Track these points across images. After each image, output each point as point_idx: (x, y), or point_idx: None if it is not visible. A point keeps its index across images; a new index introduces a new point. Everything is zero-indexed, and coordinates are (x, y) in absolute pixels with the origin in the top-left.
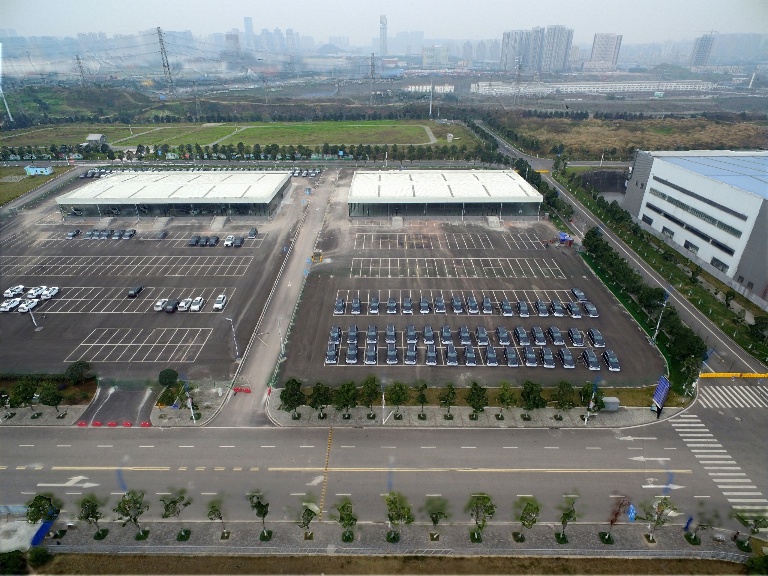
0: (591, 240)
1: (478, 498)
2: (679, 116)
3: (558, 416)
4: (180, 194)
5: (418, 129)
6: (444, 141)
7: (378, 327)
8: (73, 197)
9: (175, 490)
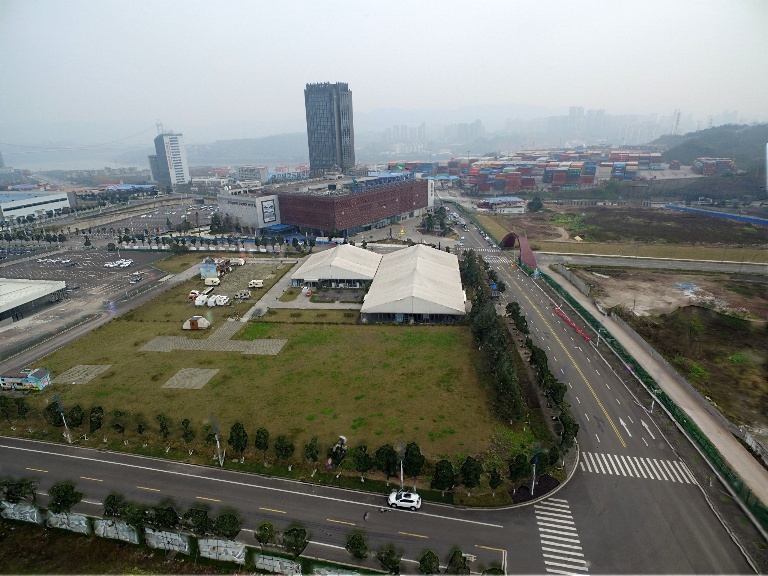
0: None
1: (53, 229)
2: None
3: None
4: None
5: None
6: None
7: (1, 255)
8: (48, 286)
9: (103, 241)
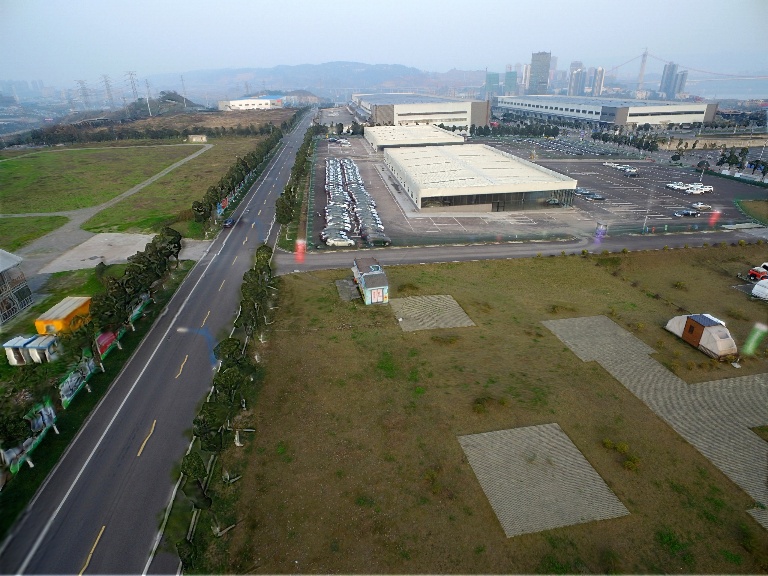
0: (476, 130)
1: (655, 137)
2: (127, 120)
3: (598, 145)
4: (496, 159)
5: (85, 150)
6: (199, 142)
7: None
8: None
9: None
